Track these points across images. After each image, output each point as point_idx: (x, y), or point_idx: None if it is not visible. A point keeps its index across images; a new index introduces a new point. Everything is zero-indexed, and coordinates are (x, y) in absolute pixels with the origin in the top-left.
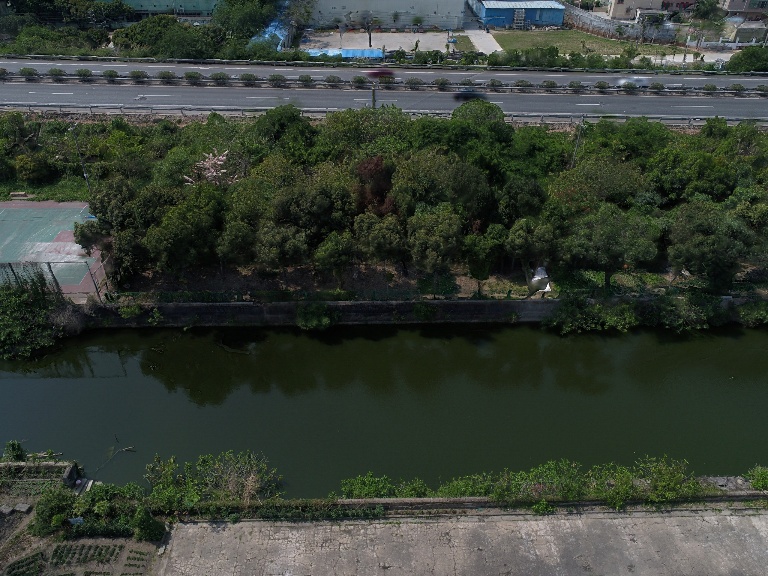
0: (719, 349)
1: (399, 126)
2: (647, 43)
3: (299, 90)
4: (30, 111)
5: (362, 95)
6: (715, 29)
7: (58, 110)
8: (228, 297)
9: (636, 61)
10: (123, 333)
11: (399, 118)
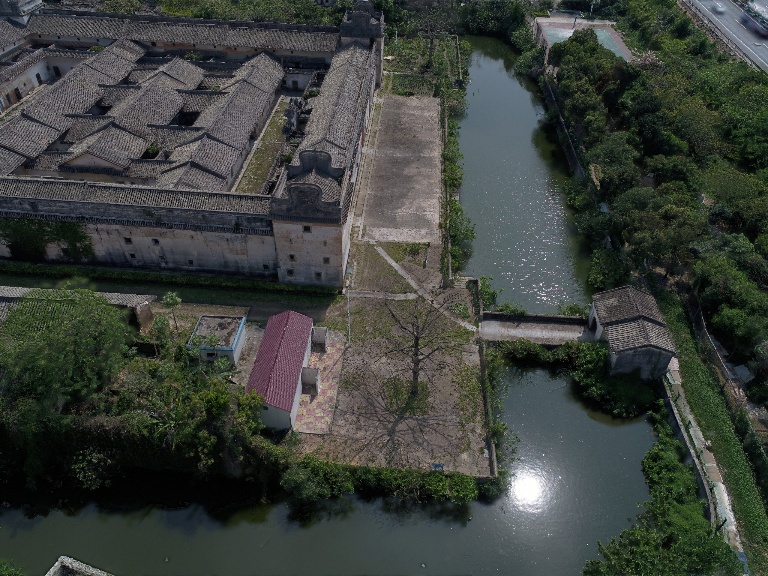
0: None
1: None
2: None
3: None
4: (708, 24)
5: None
6: None
7: (714, 29)
8: (564, 100)
9: None
10: (537, 87)
11: None
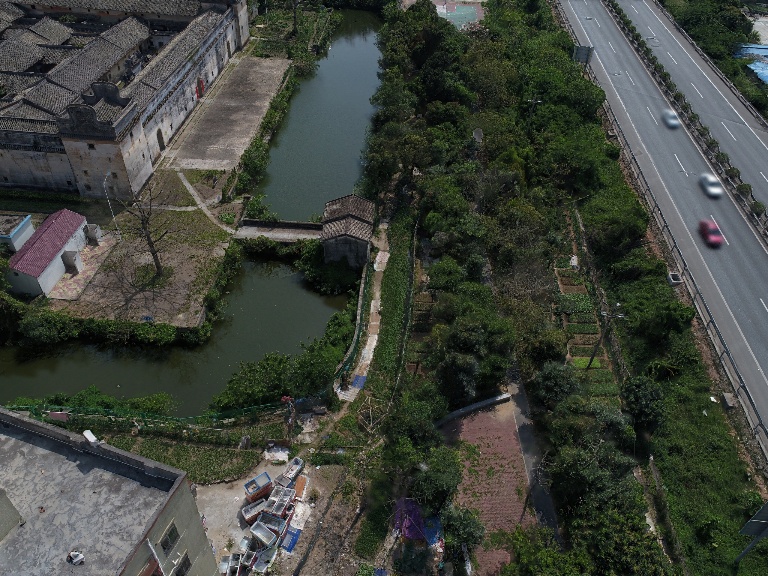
0: None
1: None
2: None
3: (635, 55)
4: None
5: (638, 74)
6: None
7: None
8: None
9: None
10: None
11: None
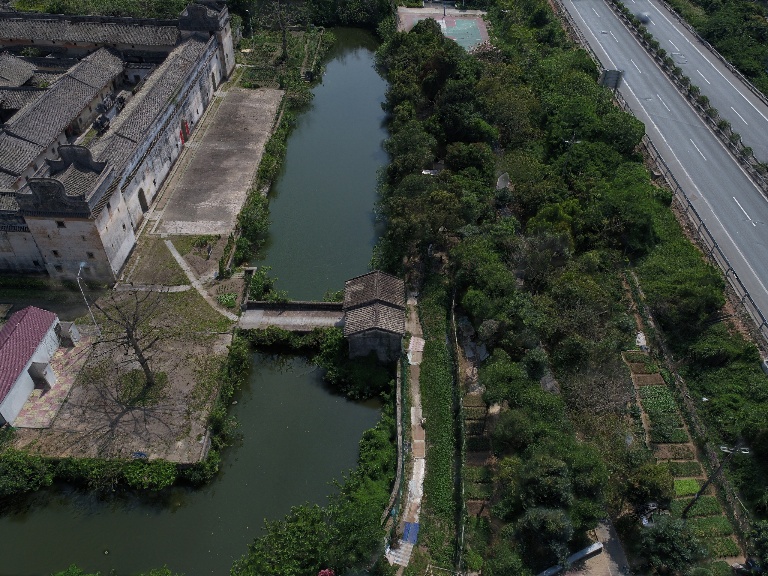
0: None
1: None
2: None
3: (662, 75)
4: None
5: (671, 97)
6: None
7: None
8: None
9: None
10: None
11: None
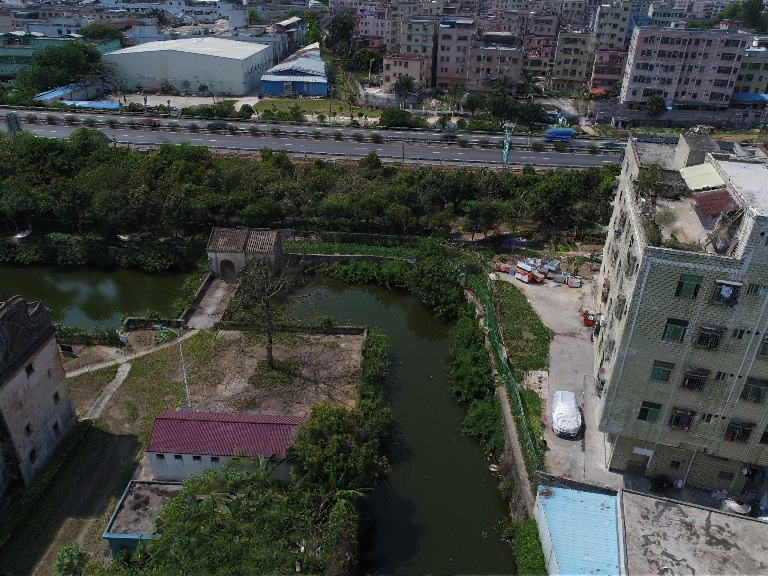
0: (94, 280)
1: (17, 143)
2: (374, 109)
3: (3, 123)
4: None
5: (44, 128)
6: (415, 99)
7: None
8: None
9: (314, 118)
10: None
11: (22, 138)
